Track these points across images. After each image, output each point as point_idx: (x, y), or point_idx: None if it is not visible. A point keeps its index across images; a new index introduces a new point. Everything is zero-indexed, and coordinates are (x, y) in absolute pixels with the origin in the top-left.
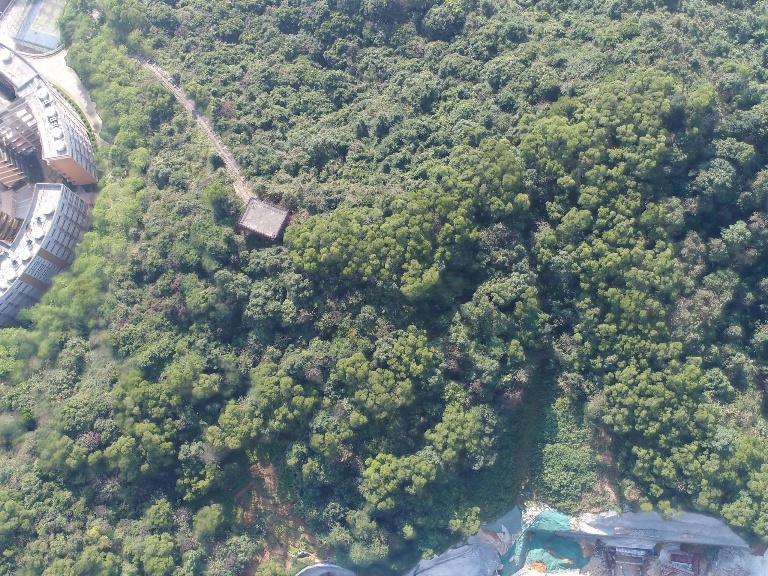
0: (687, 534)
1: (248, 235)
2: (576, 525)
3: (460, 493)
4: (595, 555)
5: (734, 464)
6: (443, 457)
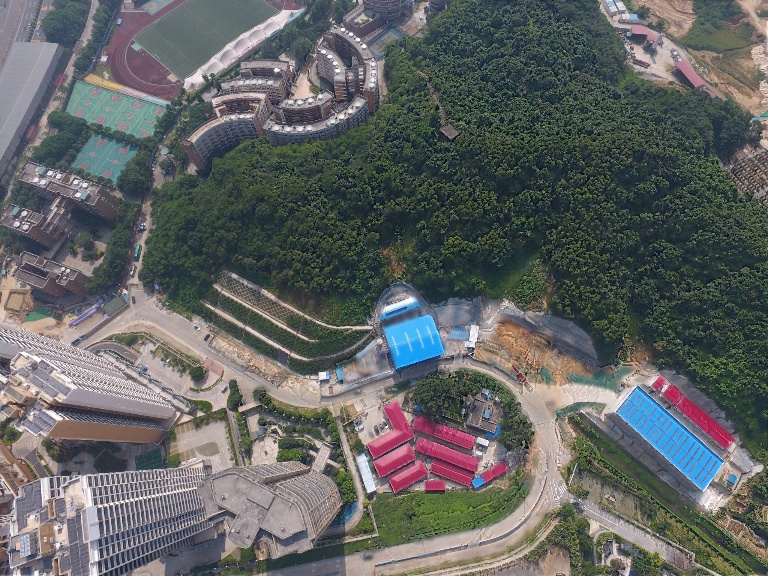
0: (571, 340)
1: (439, 137)
2: (523, 315)
3: (480, 274)
4: (524, 338)
5: (606, 302)
6: (482, 247)
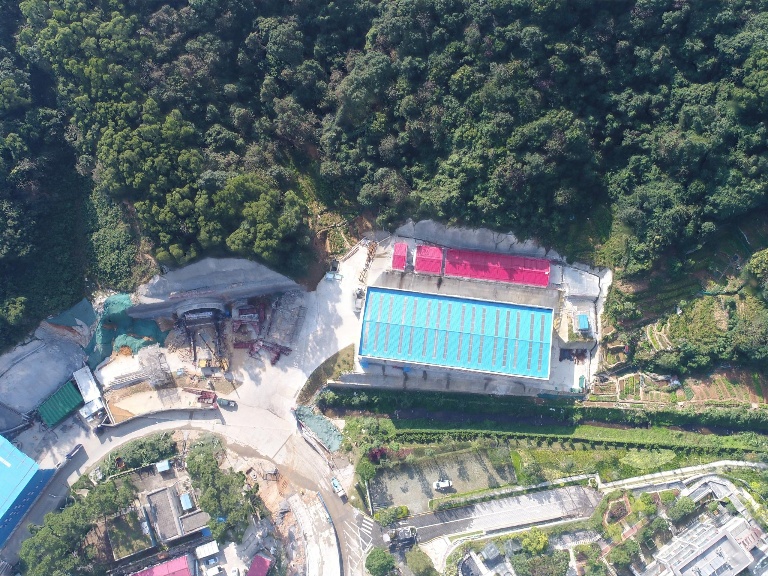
0: (236, 284)
1: None
2: (136, 300)
3: (6, 289)
4: (175, 329)
5: (222, 196)
6: None
